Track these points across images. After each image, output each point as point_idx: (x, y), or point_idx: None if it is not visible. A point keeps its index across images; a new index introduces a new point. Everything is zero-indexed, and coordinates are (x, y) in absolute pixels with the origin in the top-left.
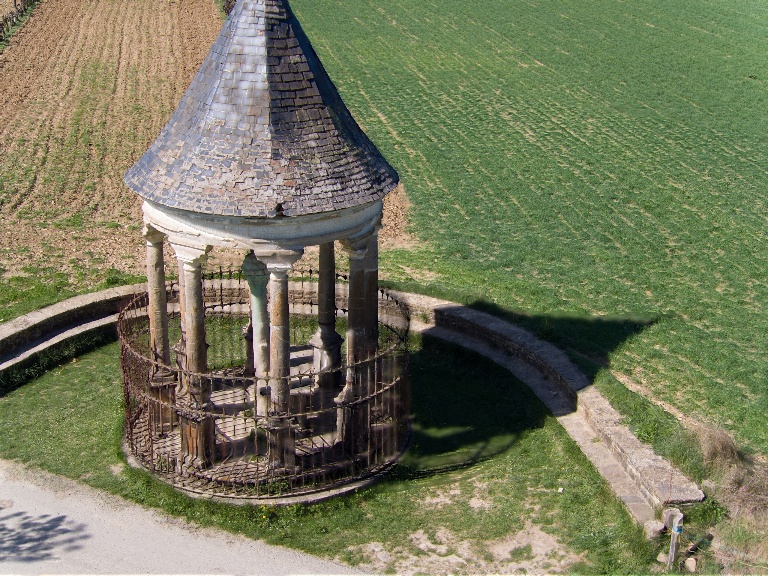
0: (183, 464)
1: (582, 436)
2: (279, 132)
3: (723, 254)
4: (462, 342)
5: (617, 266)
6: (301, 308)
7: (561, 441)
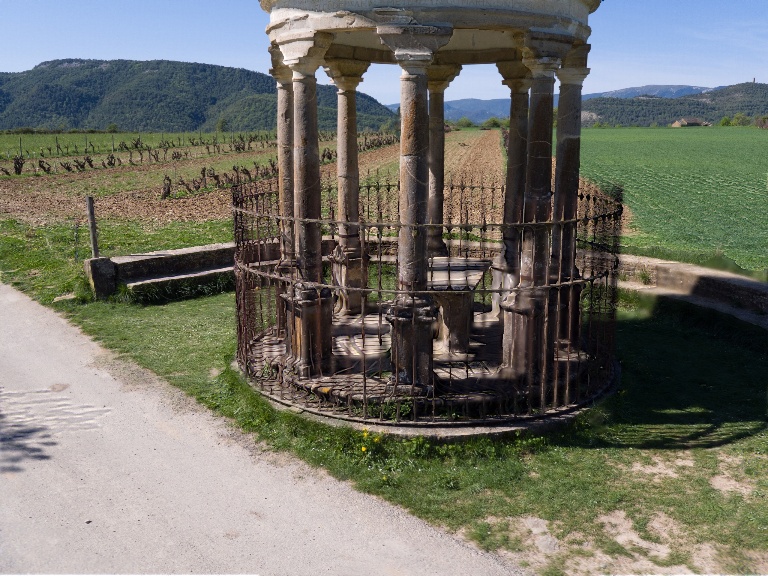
0: (284, 369)
1: None
2: None
3: None
4: (691, 300)
5: None
6: None
7: None
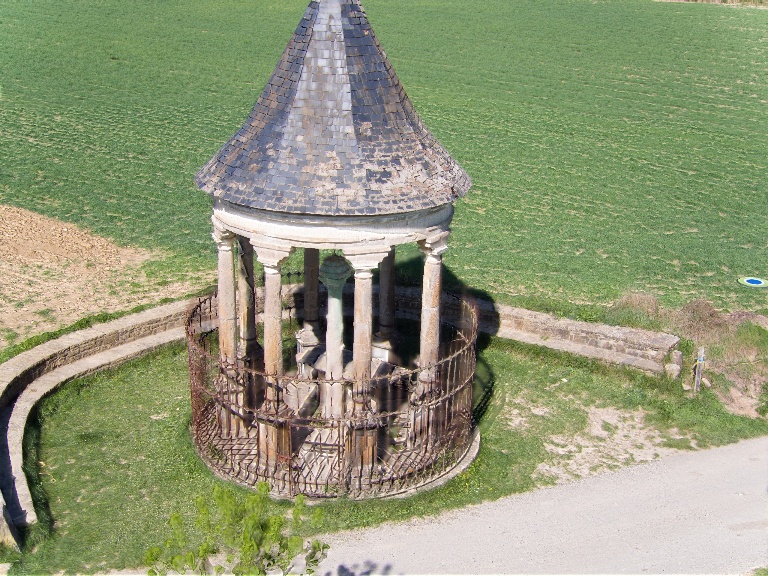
0: (362, 478)
1: (533, 339)
2: (412, 124)
3: None
4: None
5: None
6: (166, 336)
7: (522, 349)
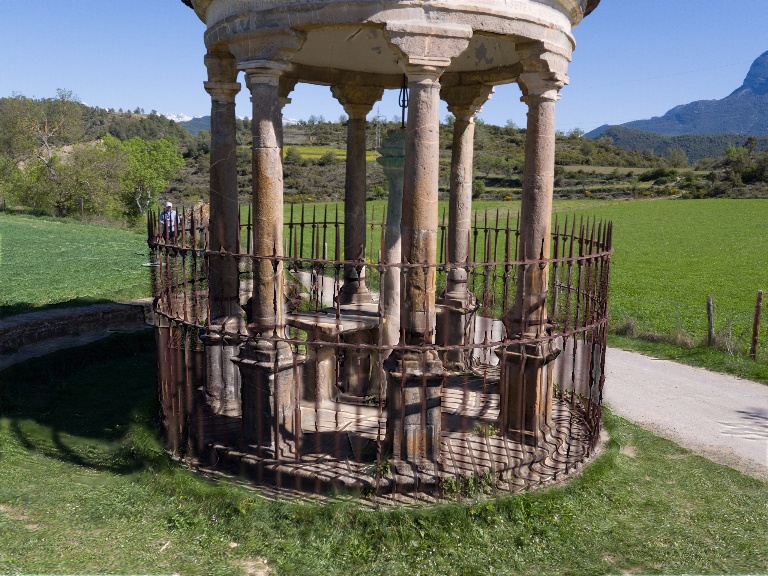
0: None
1: None
2: None
3: None
4: None
5: None
6: None
7: None
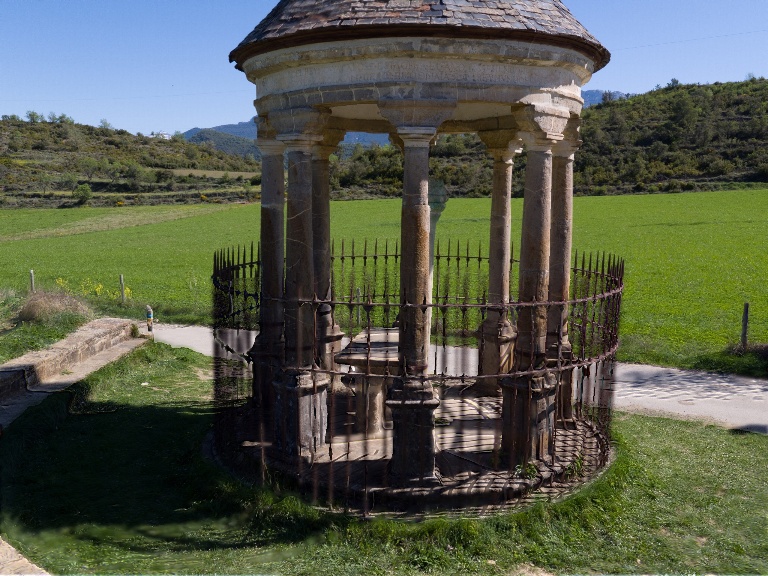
0: None
1: (72, 377)
2: None
3: None
4: None
5: None
6: None
7: None
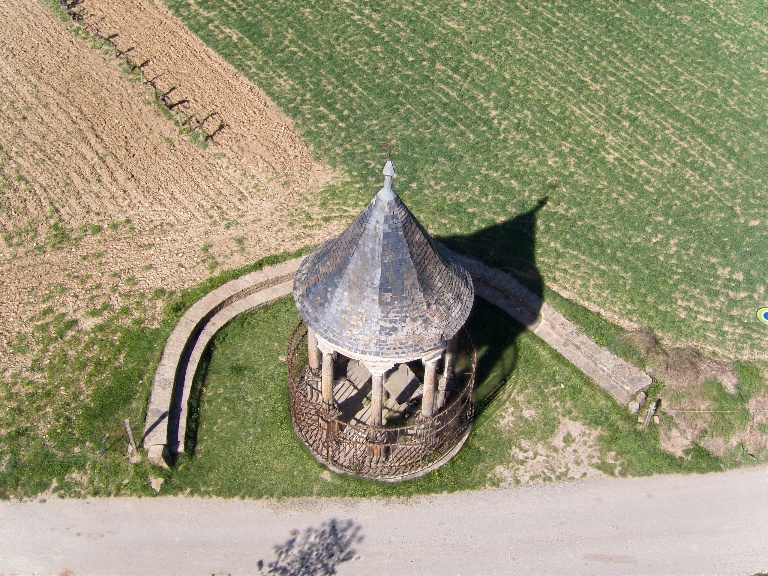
0: (372, 462)
1: (557, 344)
2: (425, 289)
3: (531, 116)
4: None
5: (478, 156)
6: None
7: (546, 350)
